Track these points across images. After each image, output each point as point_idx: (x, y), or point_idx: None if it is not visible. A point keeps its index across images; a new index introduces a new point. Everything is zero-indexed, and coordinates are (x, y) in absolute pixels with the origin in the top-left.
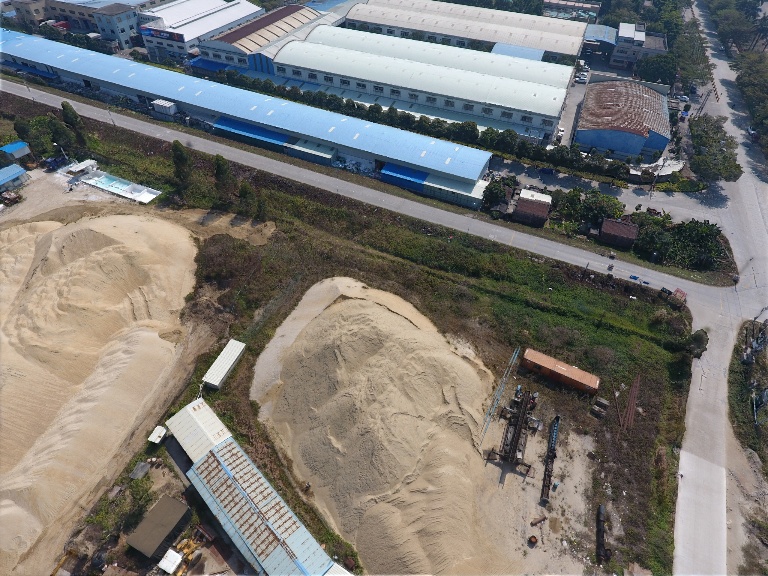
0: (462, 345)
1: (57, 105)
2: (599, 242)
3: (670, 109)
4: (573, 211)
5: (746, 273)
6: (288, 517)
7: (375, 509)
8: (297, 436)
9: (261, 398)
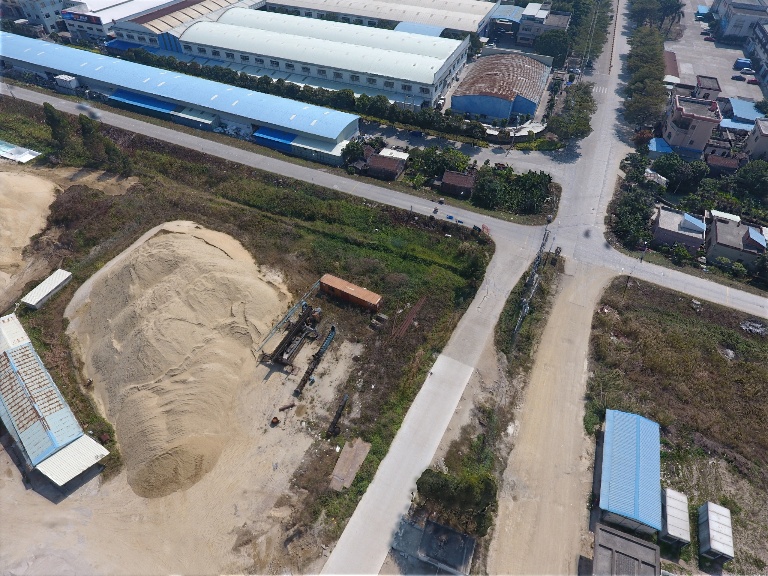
0: (273, 274)
1: None
2: (442, 192)
3: (554, 79)
4: (426, 167)
5: (564, 215)
6: (56, 401)
7: (135, 395)
8: (93, 344)
9: (72, 315)
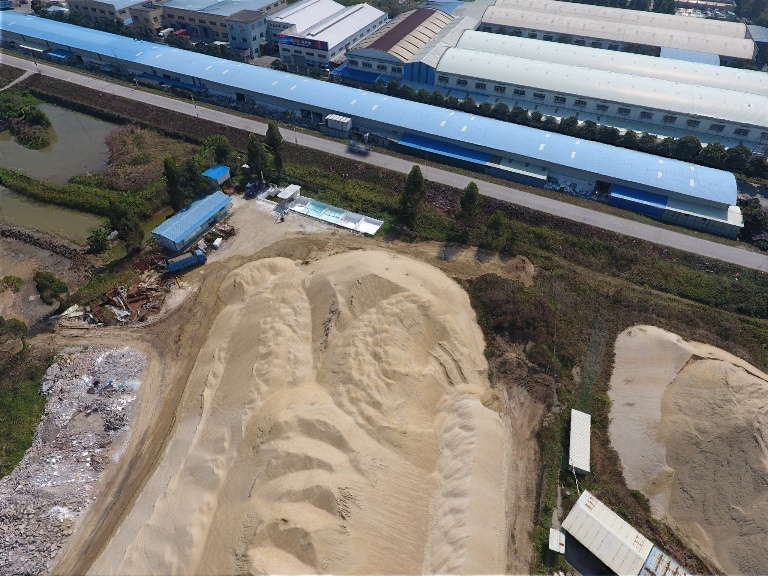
0: None
1: (223, 122)
2: None
3: None
4: None
5: None
6: None
7: None
8: (720, 542)
9: (646, 488)
